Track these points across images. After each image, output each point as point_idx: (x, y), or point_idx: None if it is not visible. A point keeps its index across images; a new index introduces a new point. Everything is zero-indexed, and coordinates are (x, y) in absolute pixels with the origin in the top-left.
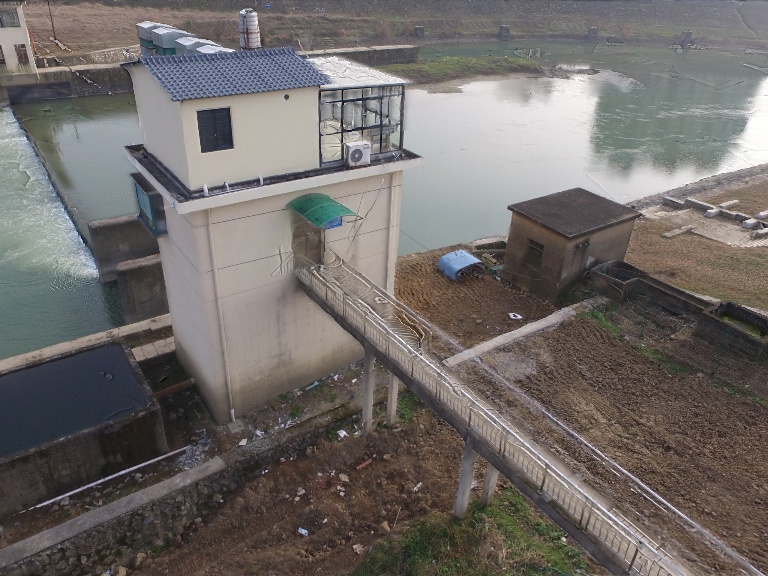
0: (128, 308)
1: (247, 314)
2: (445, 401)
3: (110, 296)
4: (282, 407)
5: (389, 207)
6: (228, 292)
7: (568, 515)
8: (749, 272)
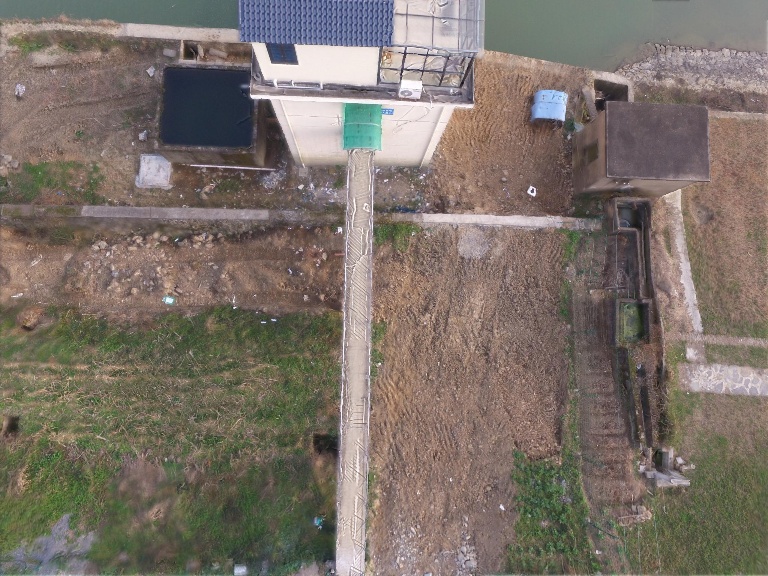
0: None
1: (312, 134)
2: None
3: None
4: (333, 175)
5: (439, 114)
6: (297, 124)
7: None
8: (764, 261)
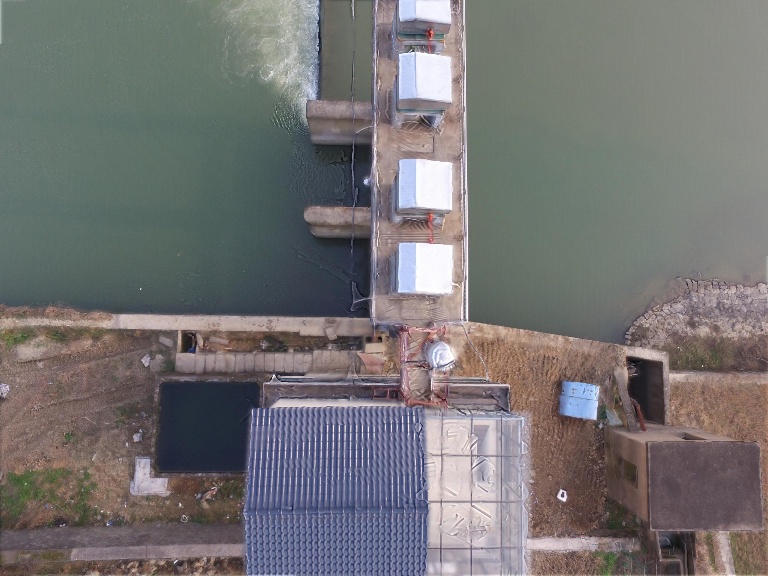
0: None
1: None
2: None
3: (313, 165)
4: None
5: None
6: None
7: None
8: None
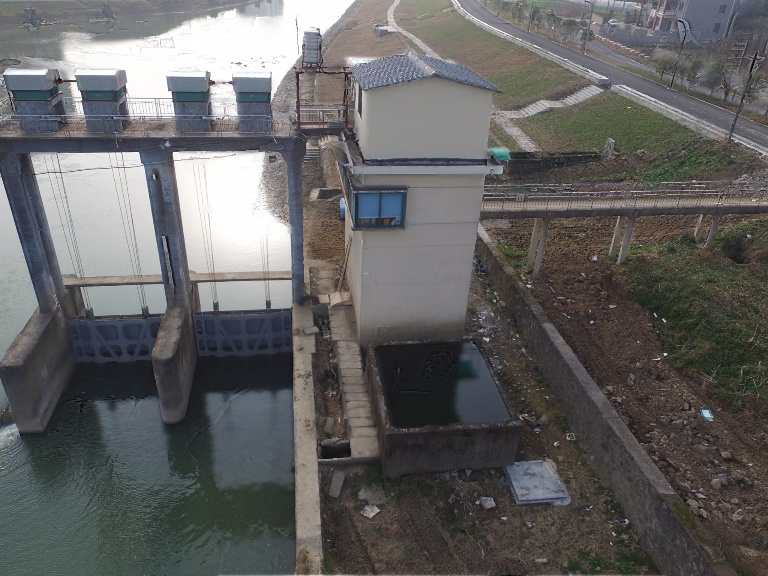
0: (177, 398)
1: None
2: (618, 205)
3: (76, 433)
4: None
5: None
6: None
7: (690, 207)
8: None
